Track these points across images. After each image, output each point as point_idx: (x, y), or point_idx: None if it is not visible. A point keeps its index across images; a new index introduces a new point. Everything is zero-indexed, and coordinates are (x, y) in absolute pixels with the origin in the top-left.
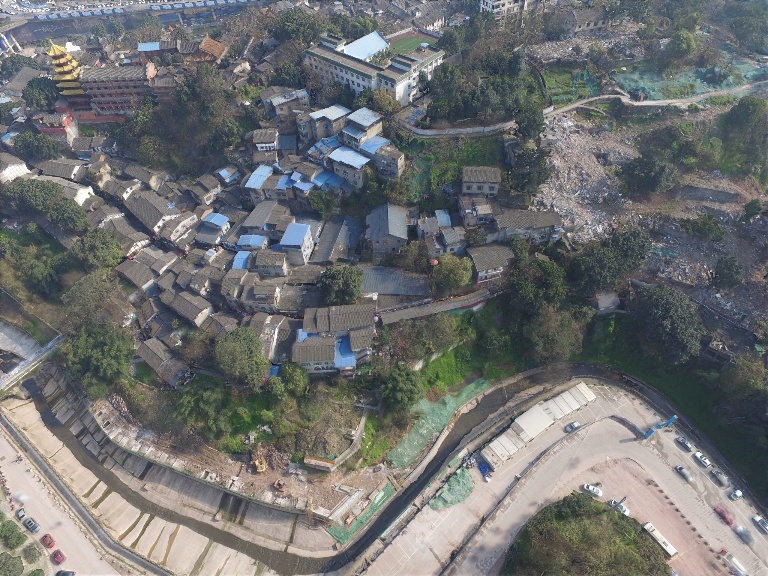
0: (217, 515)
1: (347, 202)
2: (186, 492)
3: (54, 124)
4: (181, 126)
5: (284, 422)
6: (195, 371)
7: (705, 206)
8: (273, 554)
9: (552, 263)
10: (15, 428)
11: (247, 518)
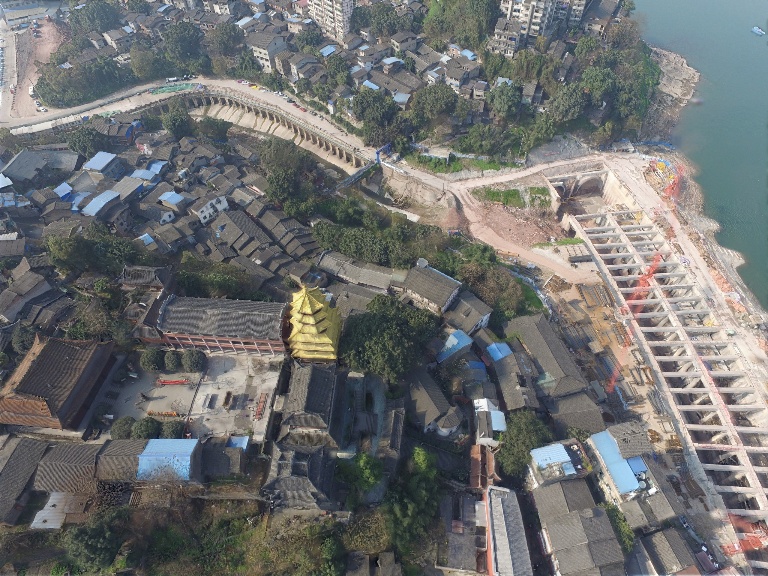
0: None
1: None
2: None
3: None
4: None
5: None
6: None
7: None
8: None
9: None
10: (343, 147)
11: None
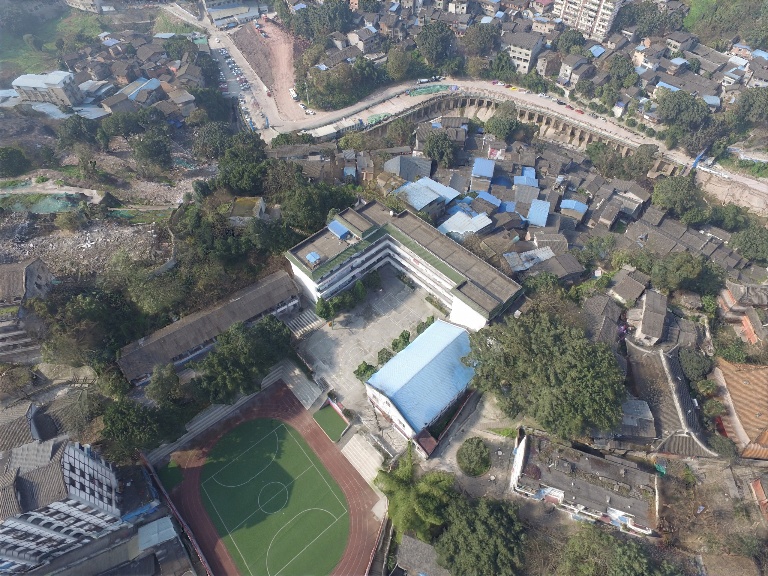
0: None
1: None
2: None
3: None
4: None
5: None
6: None
7: (124, 161)
8: None
9: (278, 144)
10: None
11: None
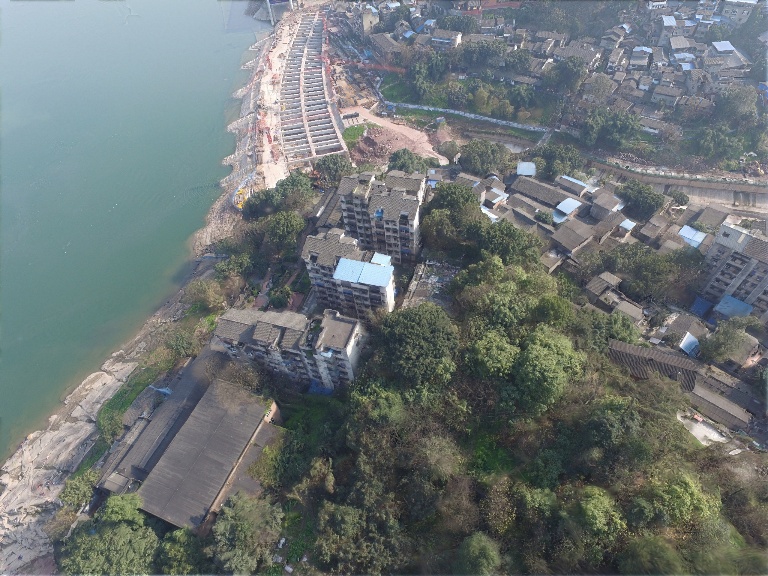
0: (736, 203)
1: (729, 36)
2: (705, 195)
3: (473, 8)
4: (573, 2)
5: (765, 148)
6: (682, 130)
7: None
8: None
9: None
10: None
11: (758, 202)
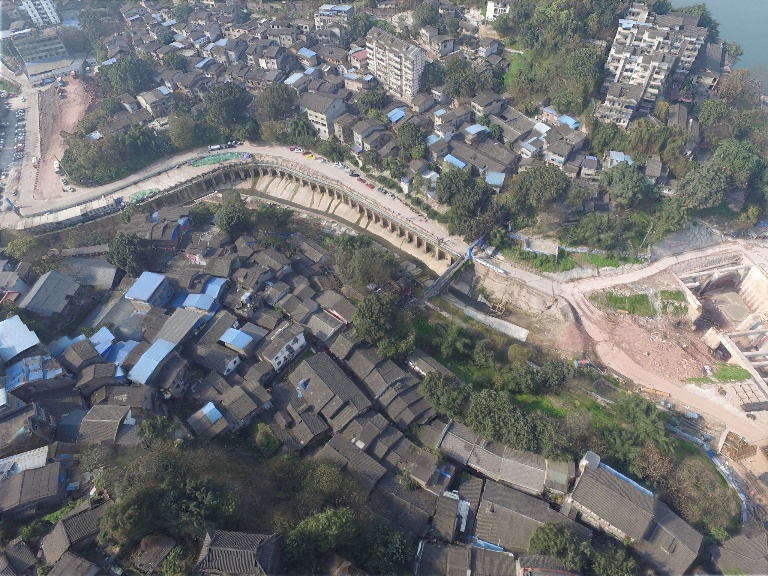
0: None
1: None
2: None
3: None
4: (260, 520)
5: None
6: None
7: None
8: (257, 195)
9: None
10: (424, 237)
11: None
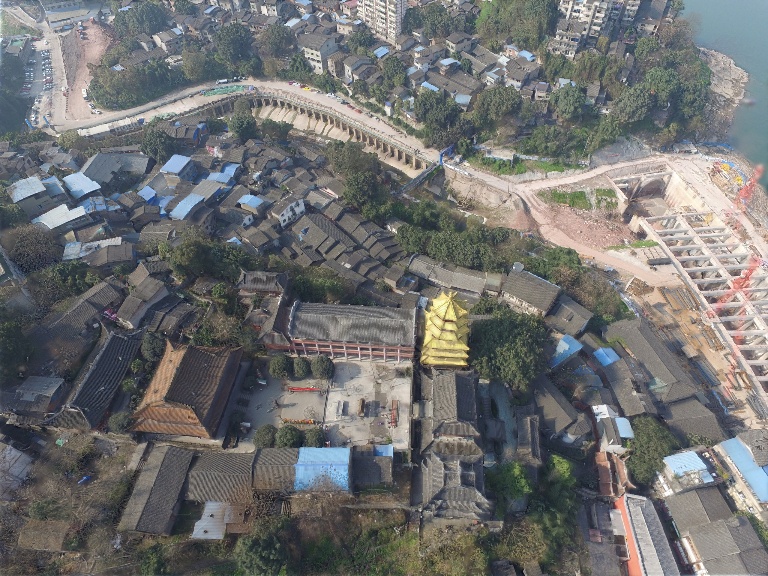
0: None
1: None
2: None
3: None
4: None
5: None
6: None
7: None
8: None
9: (2, 141)
10: (404, 149)
11: None
